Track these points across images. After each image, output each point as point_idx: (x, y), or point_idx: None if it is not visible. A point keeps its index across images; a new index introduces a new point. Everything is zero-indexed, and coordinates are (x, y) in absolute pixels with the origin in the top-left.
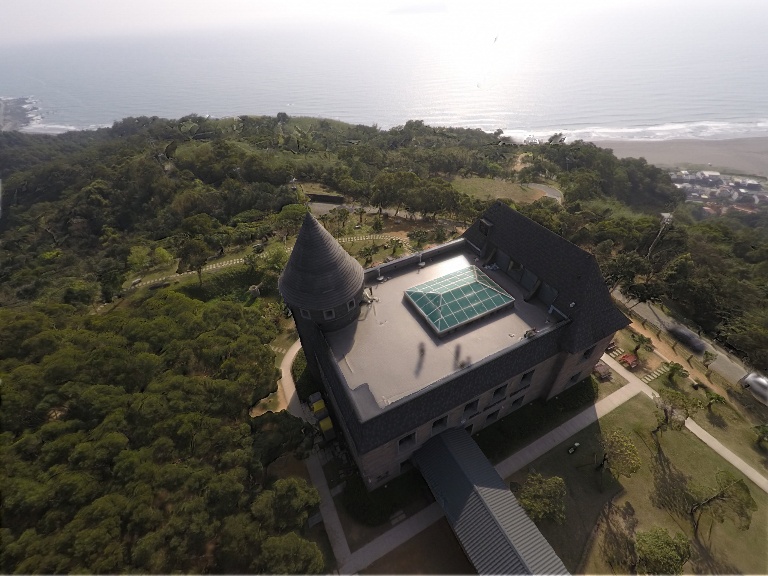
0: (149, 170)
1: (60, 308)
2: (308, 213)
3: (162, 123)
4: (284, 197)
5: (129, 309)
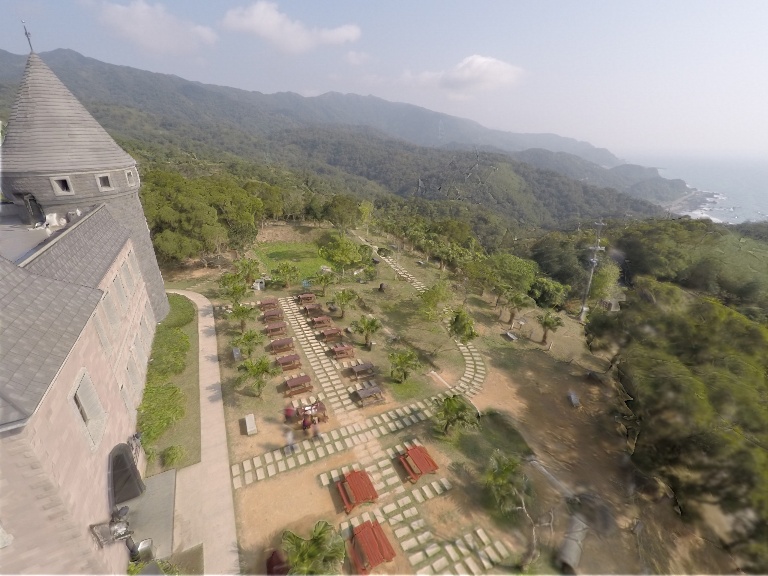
0: (616, 228)
1: (269, 189)
2: (30, 52)
3: (758, 219)
4: (571, 266)
5: (321, 234)
